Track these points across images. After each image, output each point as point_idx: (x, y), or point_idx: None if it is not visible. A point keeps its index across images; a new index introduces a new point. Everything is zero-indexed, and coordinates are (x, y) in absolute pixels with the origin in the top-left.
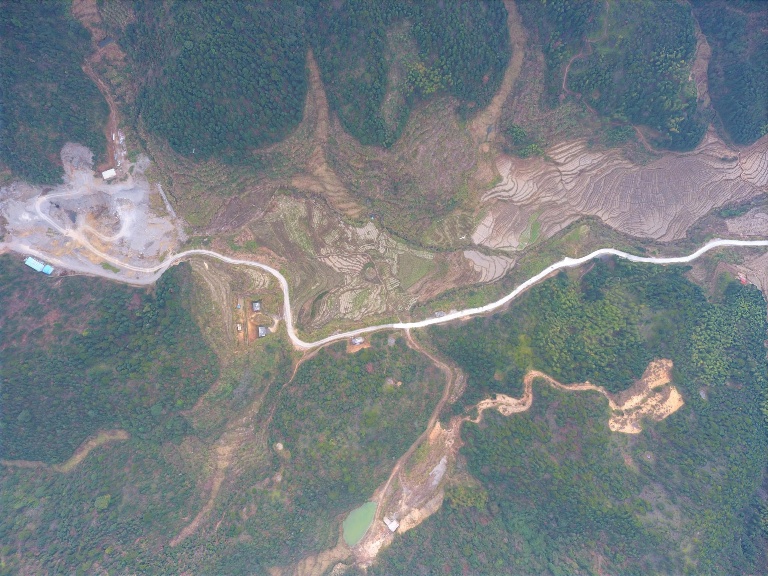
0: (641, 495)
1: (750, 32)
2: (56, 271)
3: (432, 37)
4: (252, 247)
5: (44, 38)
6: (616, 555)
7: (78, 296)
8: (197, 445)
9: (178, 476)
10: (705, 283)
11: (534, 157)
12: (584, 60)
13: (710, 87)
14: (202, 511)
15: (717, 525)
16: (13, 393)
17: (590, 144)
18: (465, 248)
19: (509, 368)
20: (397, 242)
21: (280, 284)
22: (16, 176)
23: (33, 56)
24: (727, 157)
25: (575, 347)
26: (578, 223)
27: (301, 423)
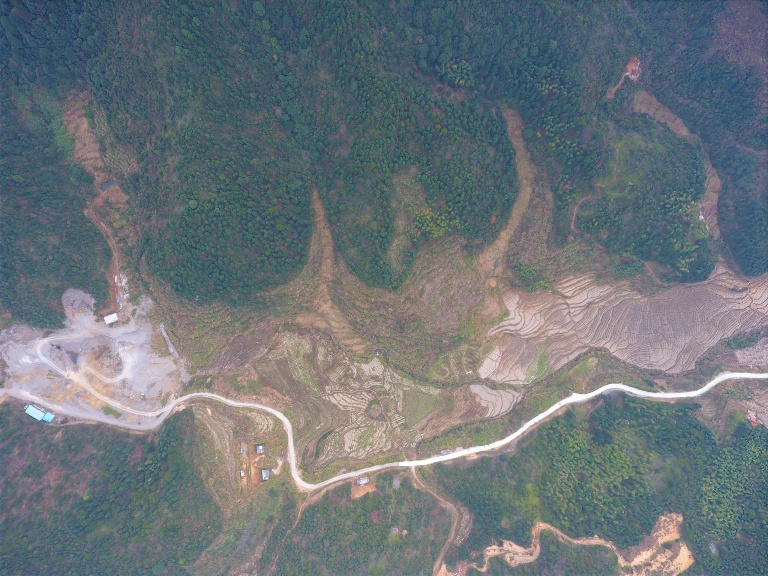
0: None
1: (761, 169)
2: (57, 418)
3: (439, 186)
4: (256, 387)
5: (46, 190)
6: None
7: (79, 449)
8: None
9: None
10: (715, 420)
11: (542, 290)
12: (593, 203)
13: (720, 220)
14: None
15: None
16: (12, 567)
17: (598, 278)
18: (471, 382)
19: (516, 518)
20: (403, 378)
21: (284, 426)
22: (17, 320)
23: (34, 210)
24: (737, 288)
25: (583, 497)
26: (586, 355)
27: None
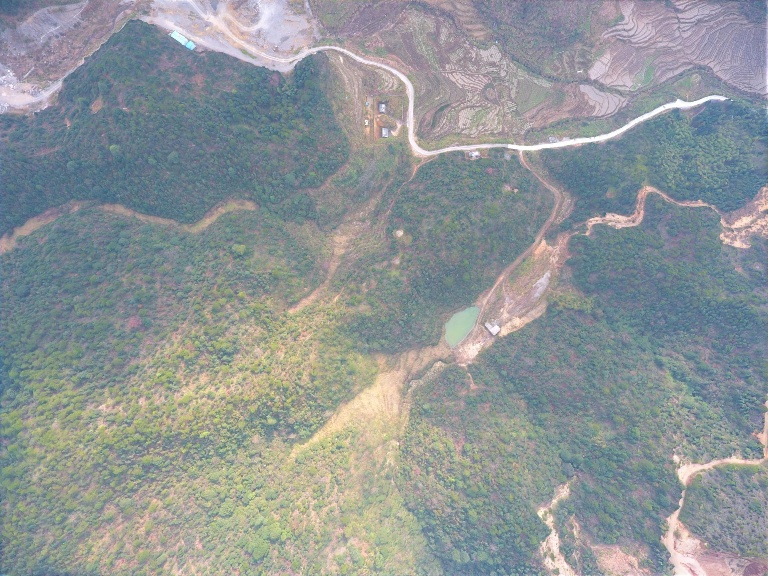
0: None
1: None
2: (198, 49)
3: None
4: (382, 53)
5: None
6: (725, 346)
7: (222, 67)
8: (316, 231)
9: (301, 250)
10: None
11: (656, 1)
12: None
13: None
14: (319, 287)
15: None
16: (167, 131)
17: None
18: (581, 82)
19: (623, 184)
20: (518, 68)
21: (406, 90)
22: None
23: None
24: None
25: (689, 170)
26: (690, 71)
27: (424, 209)
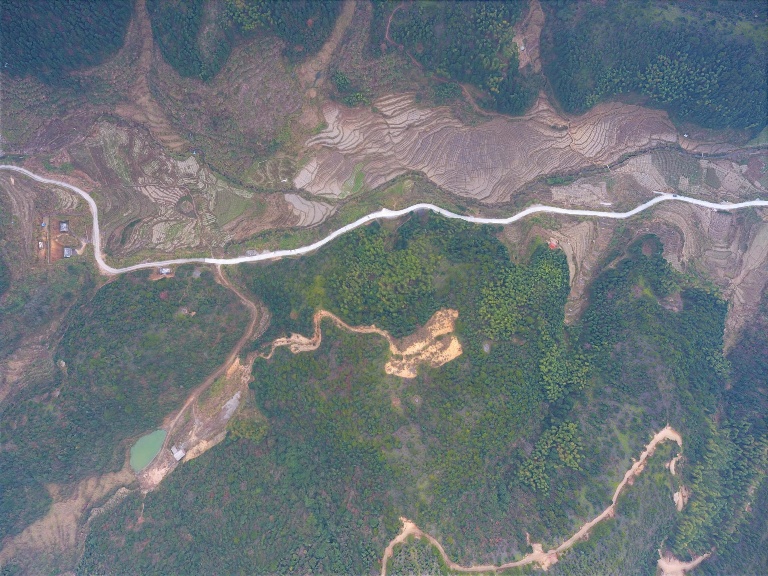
0: (395, 434)
1: (580, 1)
2: None
3: None
4: (67, 169)
5: None
6: (364, 490)
7: None
8: None
9: None
10: (518, 245)
11: (362, 107)
12: (405, 11)
13: (541, 53)
14: None
15: (459, 466)
16: None
17: (418, 99)
18: (287, 191)
19: (302, 307)
20: (217, 179)
21: (90, 207)
22: None
23: None
24: (557, 125)
25: (368, 292)
26: (403, 177)
27: (83, 341)
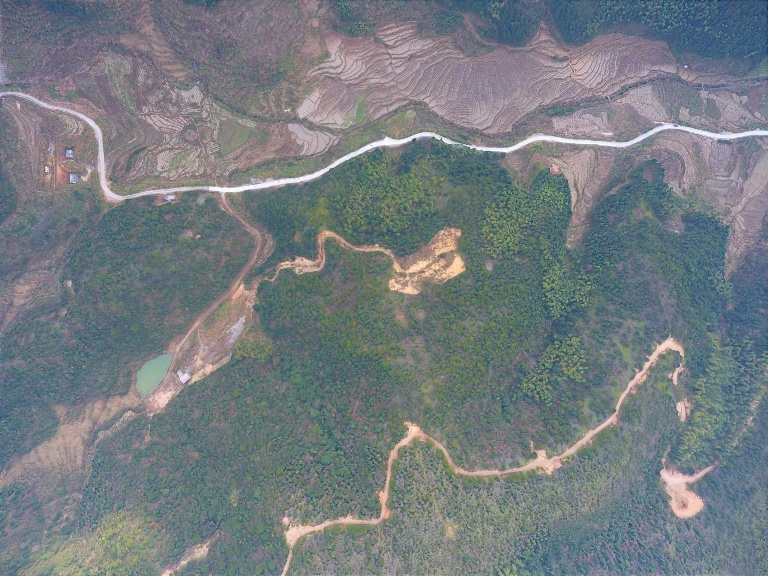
0: (400, 343)
1: None
2: None
3: None
4: (72, 97)
5: None
6: (369, 399)
7: None
8: None
9: None
10: (520, 172)
11: (364, 37)
12: None
13: None
14: None
15: (463, 372)
16: None
17: (419, 29)
18: (290, 121)
19: (306, 228)
20: (221, 108)
21: (95, 134)
22: None
23: None
24: (557, 56)
25: (372, 213)
26: (405, 107)
27: (89, 260)
